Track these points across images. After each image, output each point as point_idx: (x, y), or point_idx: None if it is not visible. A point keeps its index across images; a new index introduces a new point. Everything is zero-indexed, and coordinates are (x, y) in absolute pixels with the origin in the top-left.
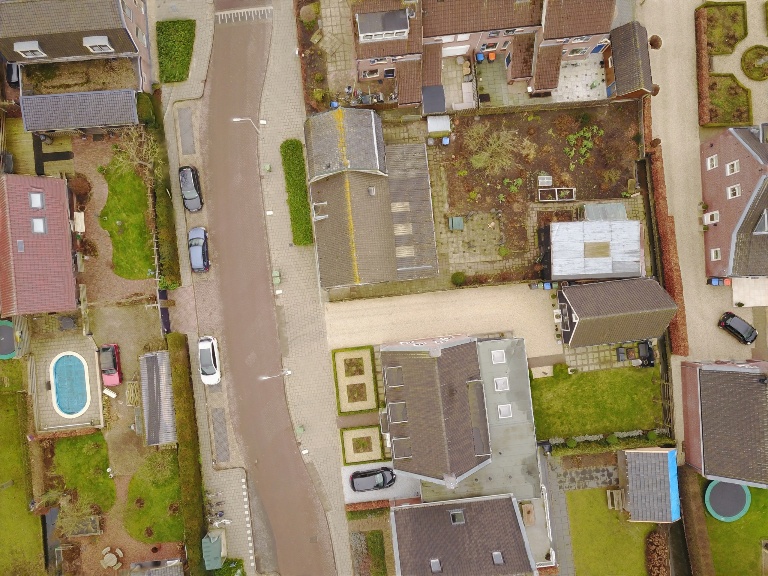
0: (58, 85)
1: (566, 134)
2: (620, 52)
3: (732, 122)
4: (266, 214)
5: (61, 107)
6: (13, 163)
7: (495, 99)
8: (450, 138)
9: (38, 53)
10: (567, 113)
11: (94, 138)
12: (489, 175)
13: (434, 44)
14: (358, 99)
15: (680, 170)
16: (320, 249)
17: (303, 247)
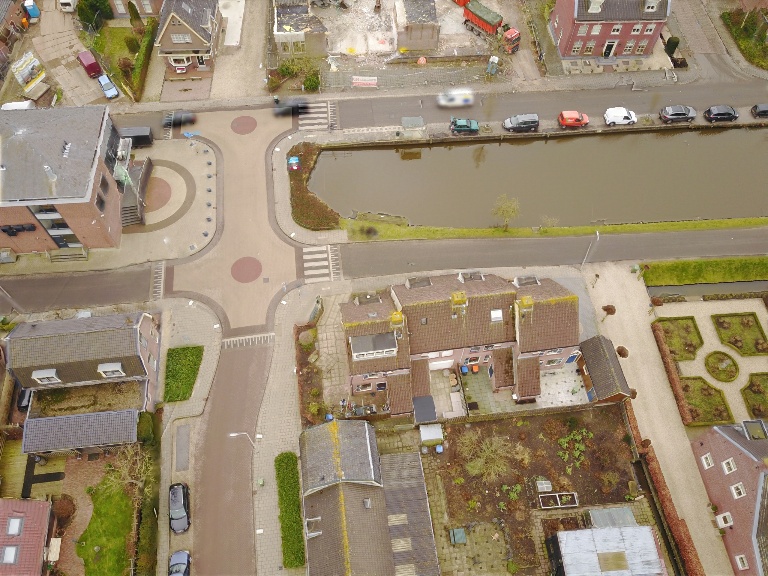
0: (65, 408)
1: (557, 438)
2: (592, 361)
3: (715, 421)
4: (256, 533)
5: (63, 428)
6: (1, 486)
7: (483, 407)
8: (443, 446)
9: (53, 379)
10: (554, 418)
11: (89, 458)
12: (486, 482)
13: (421, 360)
14: (352, 411)
15: (678, 470)
16: (312, 572)
17: (294, 570)
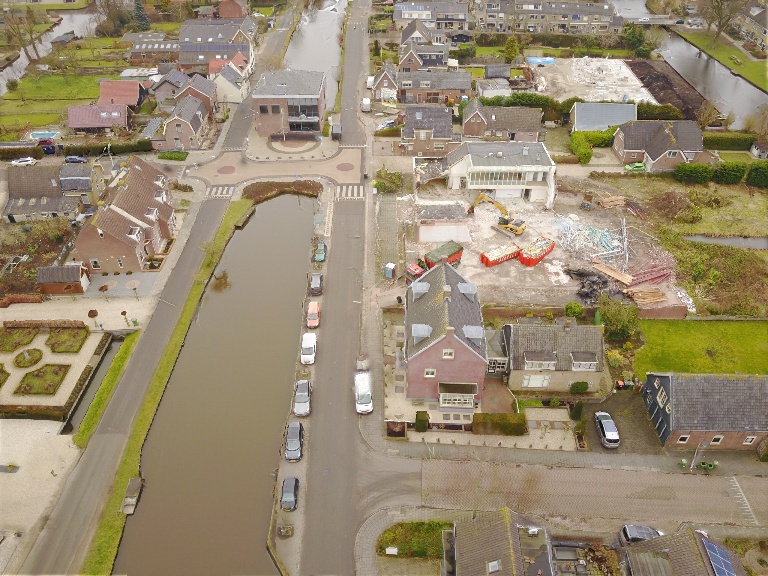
0: None
1: None
2: None
3: None
4: None
5: None
6: None
7: None
8: None
9: None
10: None
11: None
12: None
13: None
14: None
15: None
16: None
17: None
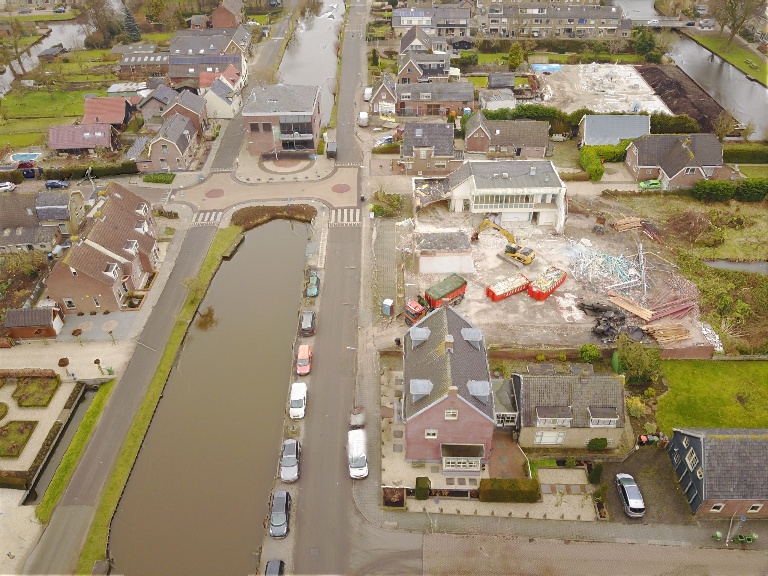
0: None
1: None
2: None
3: None
4: None
5: None
6: None
7: None
8: None
9: None
10: None
11: None
12: None
13: None
14: None
15: None
16: None
17: None
